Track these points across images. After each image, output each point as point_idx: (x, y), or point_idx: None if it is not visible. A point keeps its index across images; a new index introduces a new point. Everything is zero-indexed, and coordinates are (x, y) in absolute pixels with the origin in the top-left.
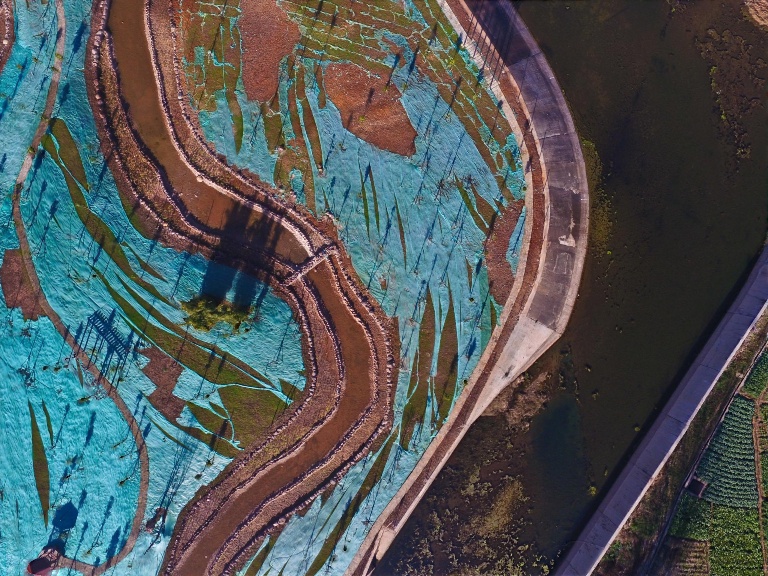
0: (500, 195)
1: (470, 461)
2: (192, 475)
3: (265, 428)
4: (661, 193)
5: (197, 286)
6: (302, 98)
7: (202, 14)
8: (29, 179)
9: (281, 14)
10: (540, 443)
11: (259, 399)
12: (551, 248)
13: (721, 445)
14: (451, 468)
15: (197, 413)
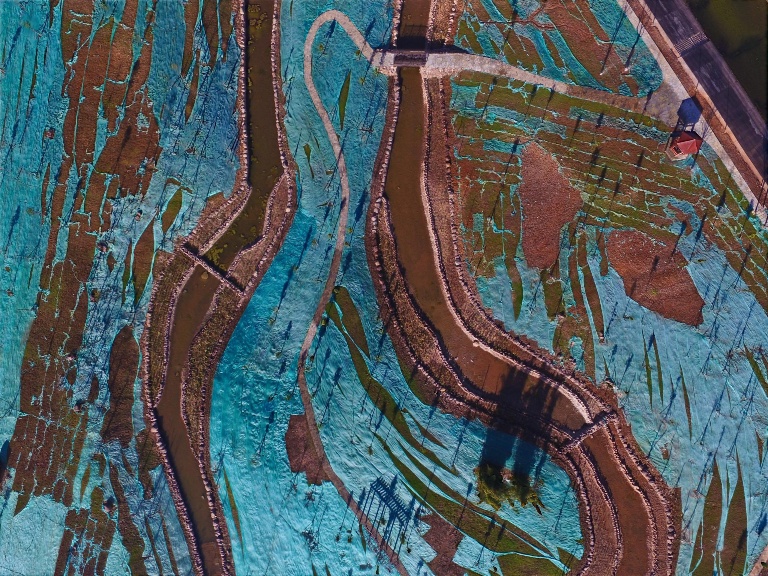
0: None
1: None
2: None
3: None
4: None
5: (477, 453)
6: (583, 265)
7: (482, 181)
8: (314, 347)
9: (563, 181)
10: None
11: (537, 567)
12: None
13: None
14: None
15: None
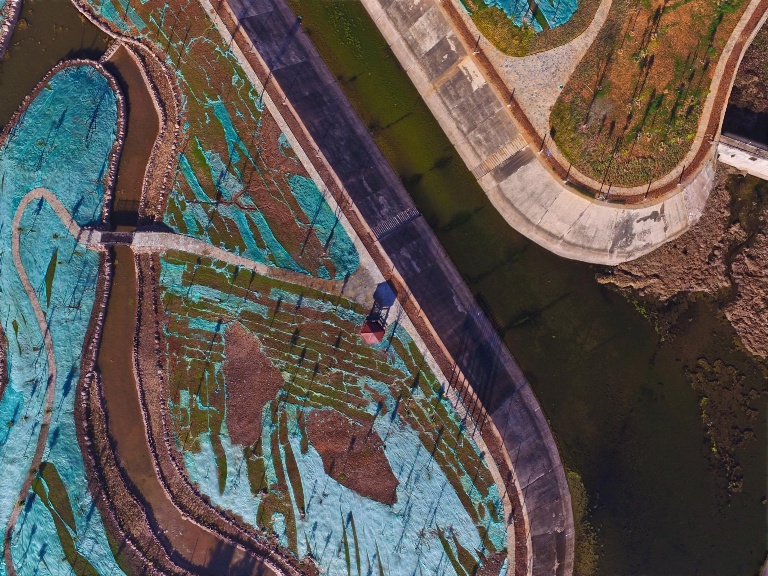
0: (482, 547)
1: None
2: None
3: None
4: (649, 525)
5: None
6: (285, 443)
7: (188, 358)
8: (20, 522)
9: (265, 360)
10: None
11: None
12: None
13: None
14: None
15: None
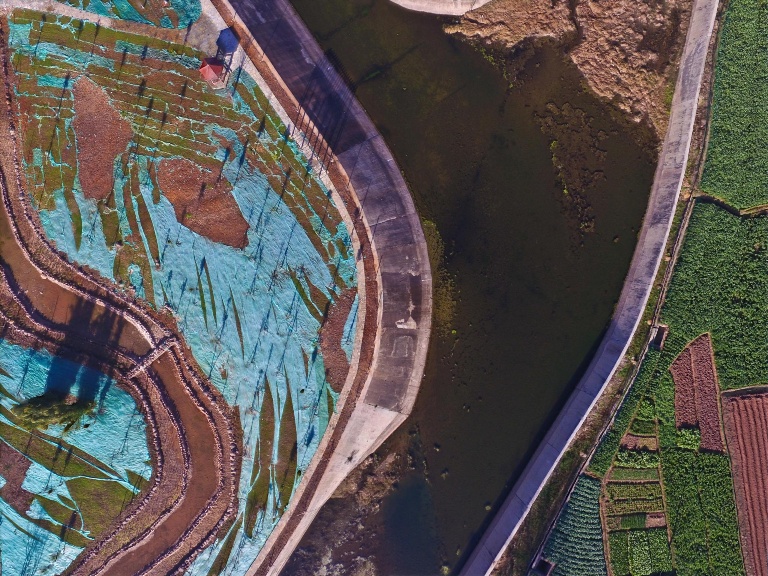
0: (332, 284)
1: (322, 543)
2: (44, 565)
3: (114, 518)
4: (505, 270)
5: (42, 382)
6: (137, 194)
7: (38, 117)
8: None
9: (114, 113)
10: (392, 523)
11: (106, 490)
12: (387, 334)
13: (567, 525)
14: (303, 550)
15: (46, 506)
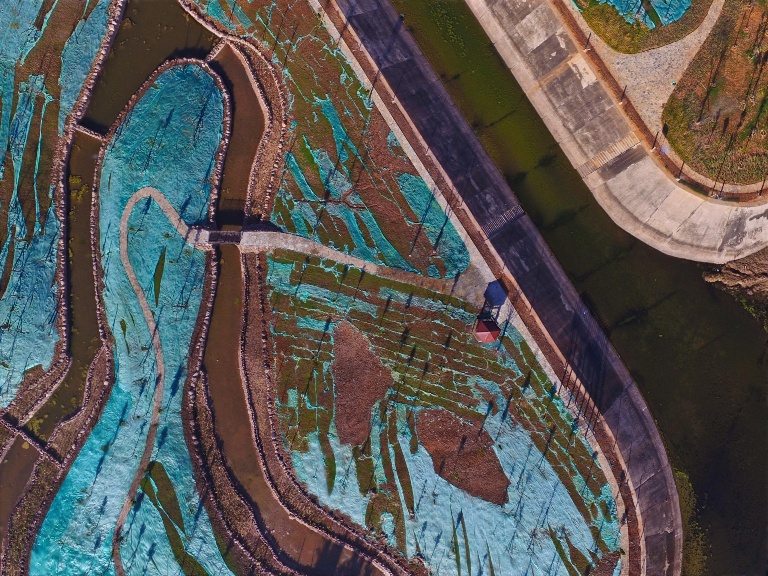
0: (595, 547)
1: None
2: None
3: None
4: (758, 526)
5: None
6: (394, 443)
7: (296, 358)
8: (129, 522)
9: (374, 360)
10: None
11: None
12: None
13: None
14: None
15: None
